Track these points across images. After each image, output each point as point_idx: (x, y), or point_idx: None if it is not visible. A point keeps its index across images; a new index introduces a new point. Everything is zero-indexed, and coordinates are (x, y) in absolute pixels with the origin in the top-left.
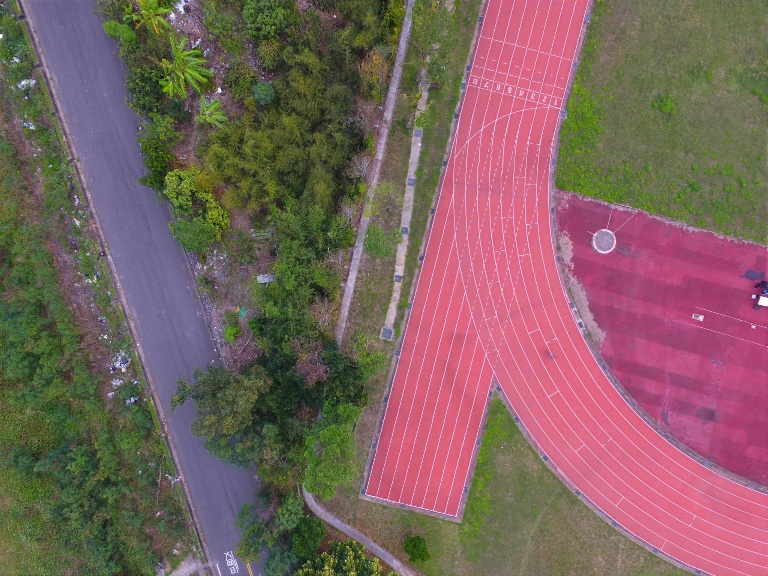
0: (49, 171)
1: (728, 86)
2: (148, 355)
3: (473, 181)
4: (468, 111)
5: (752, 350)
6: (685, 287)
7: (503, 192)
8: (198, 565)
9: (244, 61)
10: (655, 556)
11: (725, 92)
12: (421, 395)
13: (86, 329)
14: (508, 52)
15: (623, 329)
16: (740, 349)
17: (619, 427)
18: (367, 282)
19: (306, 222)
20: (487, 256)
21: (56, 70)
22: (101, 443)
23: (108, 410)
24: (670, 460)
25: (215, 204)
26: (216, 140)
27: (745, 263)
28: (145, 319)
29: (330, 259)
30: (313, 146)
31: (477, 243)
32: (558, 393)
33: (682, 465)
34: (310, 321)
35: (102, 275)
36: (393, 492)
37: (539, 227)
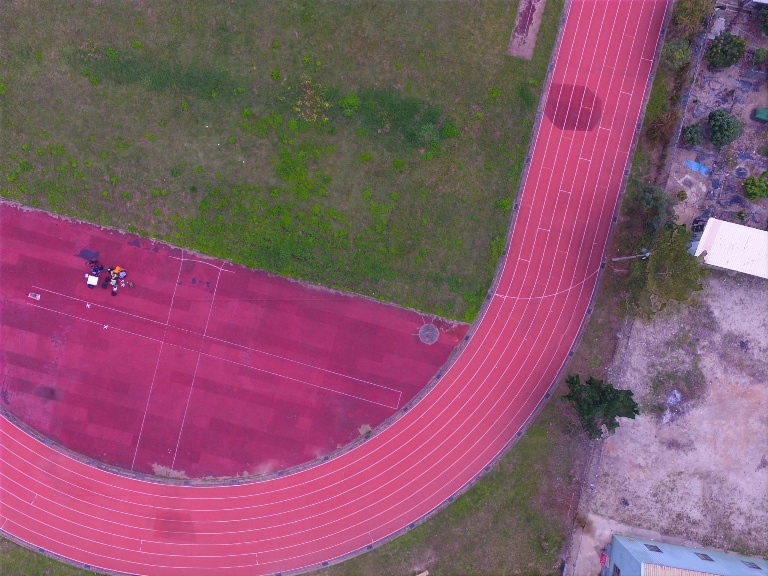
0: None
1: (58, 67)
2: None
3: None
4: None
5: (90, 329)
6: (20, 266)
7: None
8: None
9: None
10: None
11: (56, 73)
12: None
13: None
14: None
15: None
16: (78, 328)
17: None
18: None
19: None
20: None
21: None
22: None
23: None
24: (10, 439)
25: None
26: None
27: (79, 242)
28: None
29: None
30: None
31: None
32: None
33: (23, 444)
34: None
35: None
36: None
37: None
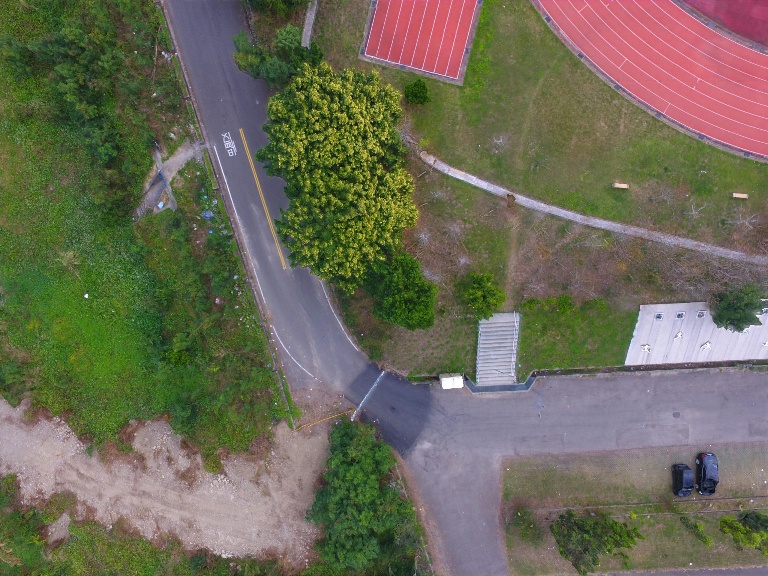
0: None
1: None
2: None
3: None
4: None
5: None
6: None
7: None
8: (195, 150)
9: None
10: (658, 120)
11: None
12: None
13: None
14: None
15: None
16: None
17: None
18: None
19: None
20: None
21: None
22: (95, 3)
23: None
24: (674, 21)
25: None
26: None
27: None
28: None
29: None
30: None
31: None
32: None
33: (686, 26)
34: None
35: None
36: (393, 52)
37: None
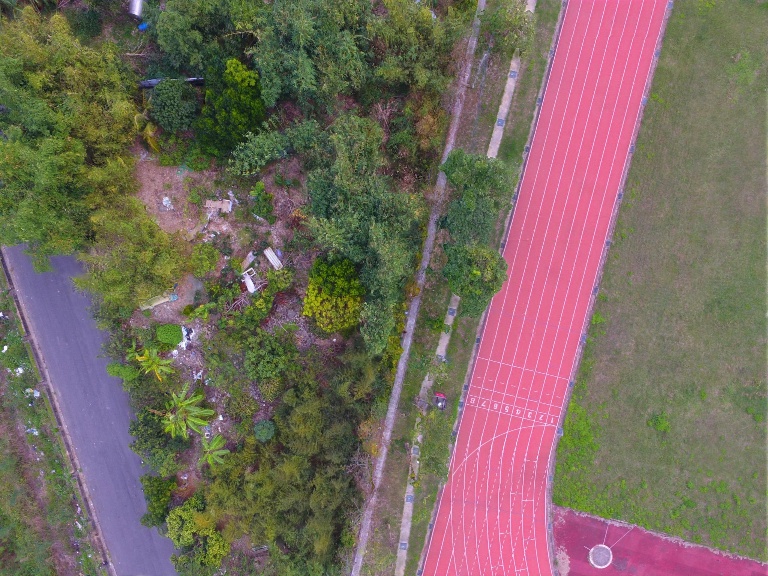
0: (52, 477)
1: (722, 405)
2: None
3: (471, 498)
4: (466, 429)
5: None
6: None
7: (500, 508)
8: None
9: (245, 391)
10: None
11: (719, 410)
12: None
13: None
14: (505, 372)
15: None
16: None
17: None
18: None
19: (306, 566)
20: (485, 571)
21: (60, 385)
22: None
23: None
24: None
25: (216, 537)
26: (217, 473)
27: None
28: None
29: None
30: (313, 494)
31: (475, 558)
32: None
33: None
34: None
35: None
36: None
37: (536, 542)
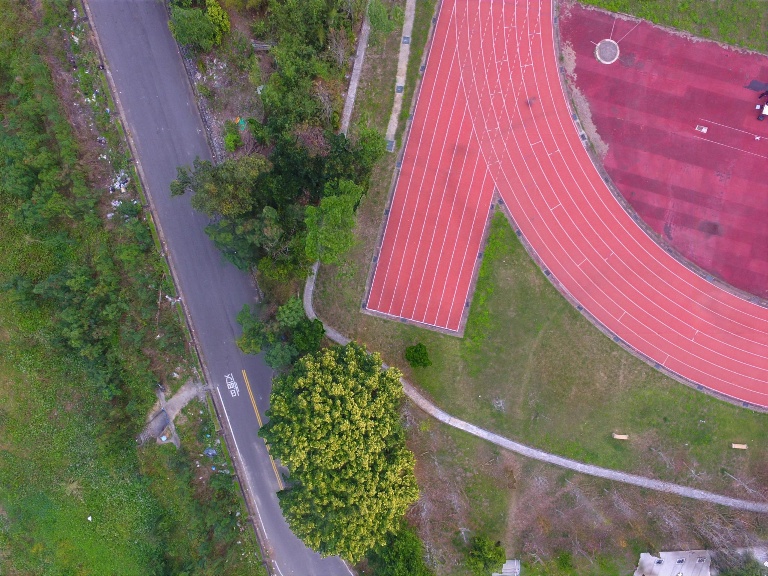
0: None
1: None
2: (148, 173)
3: None
4: None
5: (756, 162)
6: (689, 98)
7: (505, 1)
8: (198, 389)
9: None
10: (657, 371)
11: None
12: (422, 207)
13: (85, 148)
14: None
15: (626, 141)
16: (744, 161)
17: (621, 241)
18: (368, 92)
19: (307, 14)
20: (489, 66)
21: None
22: (101, 257)
23: (108, 230)
24: (673, 274)
25: (215, 3)
26: None
27: (749, 74)
28: (144, 136)
29: (331, 55)
30: None
31: (479, 53)
32: (560, 206)
33: (685, 279)
34: (311, 108)
35: (101, 89)
36: (394, 306)
37: (542, 37)
